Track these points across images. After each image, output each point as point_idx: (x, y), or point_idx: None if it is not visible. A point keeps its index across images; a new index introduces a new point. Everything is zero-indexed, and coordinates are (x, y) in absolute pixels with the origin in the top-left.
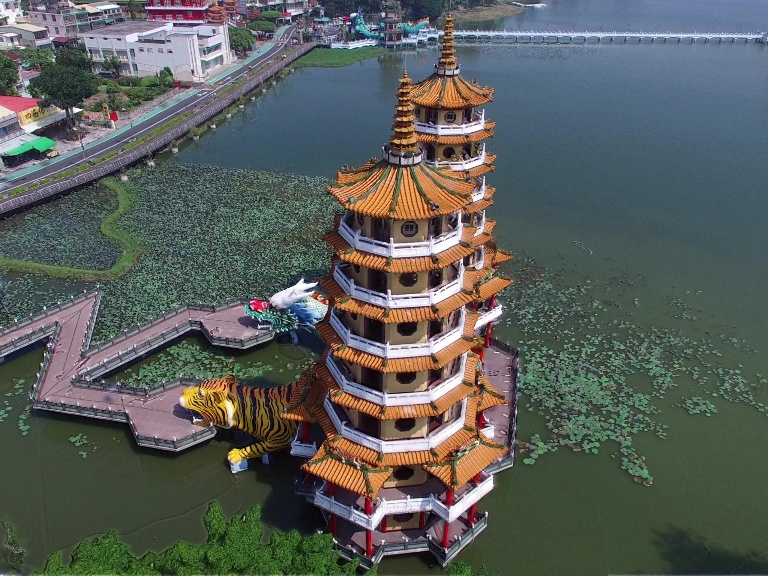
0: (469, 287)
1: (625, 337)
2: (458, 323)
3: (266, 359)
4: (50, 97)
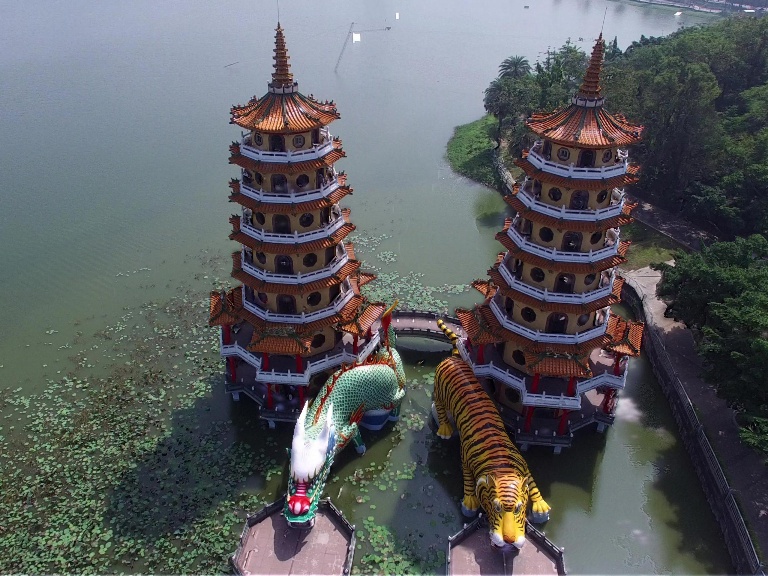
0: None
1: None
2: None
3: None
4: None
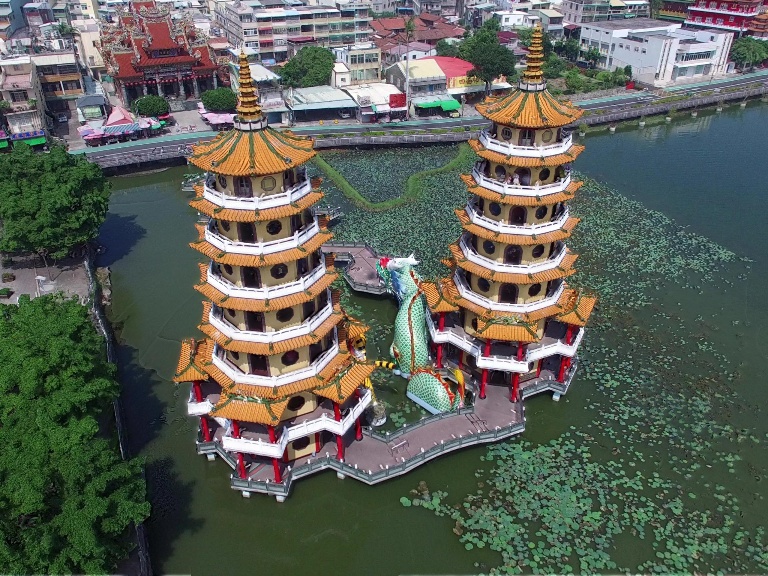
0: (278, 259)
1: (701, 507)
2: (272, 288)
3: (367, 307)
4: (475, 69)
